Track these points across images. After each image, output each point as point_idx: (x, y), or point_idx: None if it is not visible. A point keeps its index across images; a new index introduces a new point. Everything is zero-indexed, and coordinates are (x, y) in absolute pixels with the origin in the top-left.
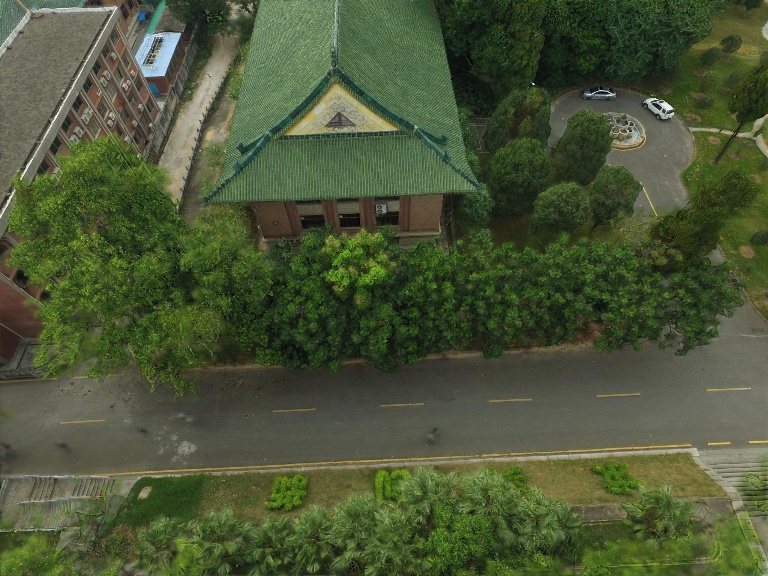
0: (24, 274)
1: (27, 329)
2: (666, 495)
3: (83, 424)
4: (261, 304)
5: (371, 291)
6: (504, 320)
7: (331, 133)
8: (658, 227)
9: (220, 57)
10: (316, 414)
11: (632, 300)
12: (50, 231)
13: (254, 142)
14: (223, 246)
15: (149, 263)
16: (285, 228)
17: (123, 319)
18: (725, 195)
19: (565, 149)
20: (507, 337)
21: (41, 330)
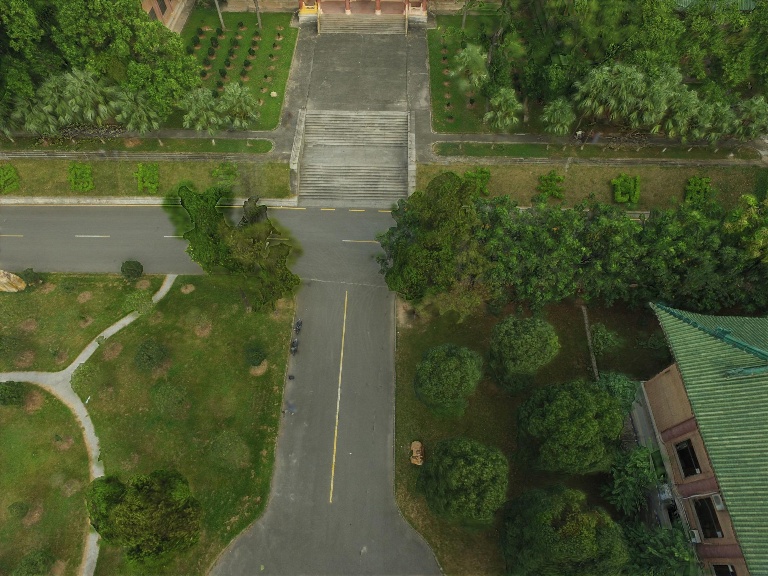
0: None
1: None
2: (507, 105)
3: None
4: None
5: None
6: None
7: None
8: None
9: None
10: None
11: None
12: None
13: None
14: None
15: None
16: None
17: None
18: None
19: None
20: None
21: None
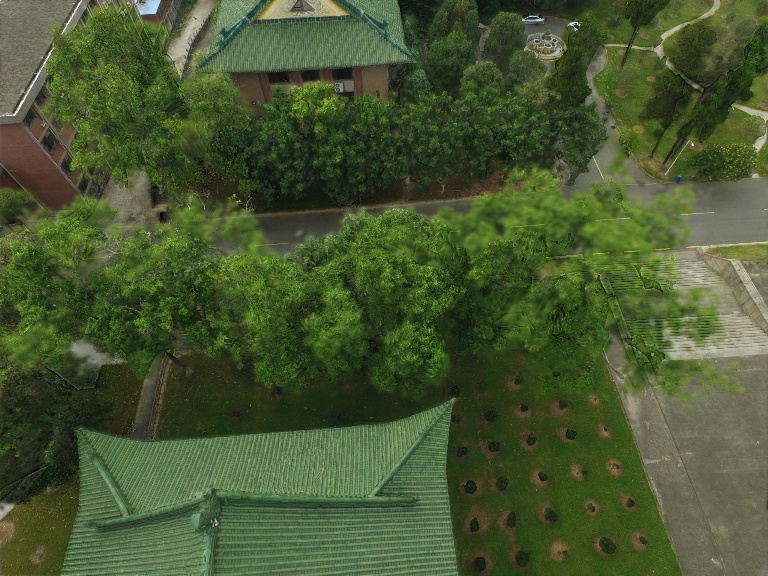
0: (56, 119)
1: (49, 200)
2: None
3: (101, 259)
4: (242, 141)
5: (327, 129)
6: (428, 147)
7: (295, 17)
8: (547, 80)
9: (204, 4)
10: (289, 246)
11: (523, 127)
12: (80, 71)
13: (234, 27)
14: (211, 120)
15: (156, 91)
16: (262, 109)
17: (129, 191)
18: (581, 36)
19: (490, 46)
20: (432, 163)
21: (60, 201)
